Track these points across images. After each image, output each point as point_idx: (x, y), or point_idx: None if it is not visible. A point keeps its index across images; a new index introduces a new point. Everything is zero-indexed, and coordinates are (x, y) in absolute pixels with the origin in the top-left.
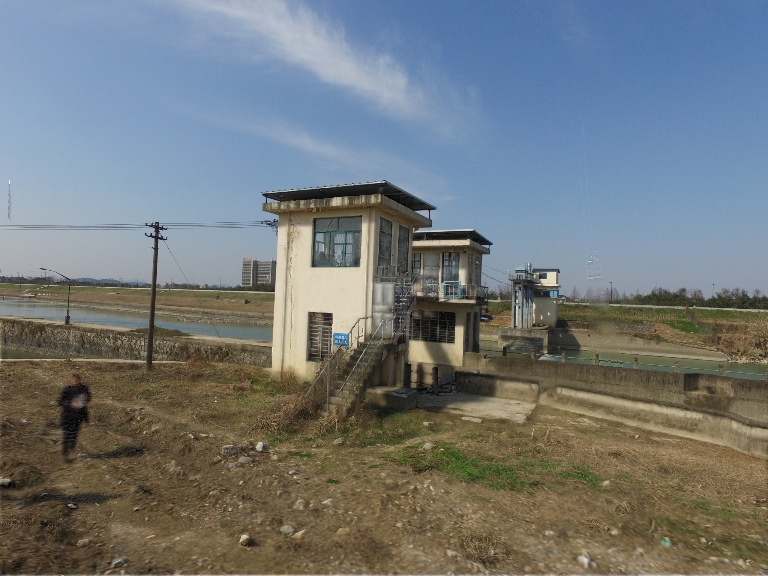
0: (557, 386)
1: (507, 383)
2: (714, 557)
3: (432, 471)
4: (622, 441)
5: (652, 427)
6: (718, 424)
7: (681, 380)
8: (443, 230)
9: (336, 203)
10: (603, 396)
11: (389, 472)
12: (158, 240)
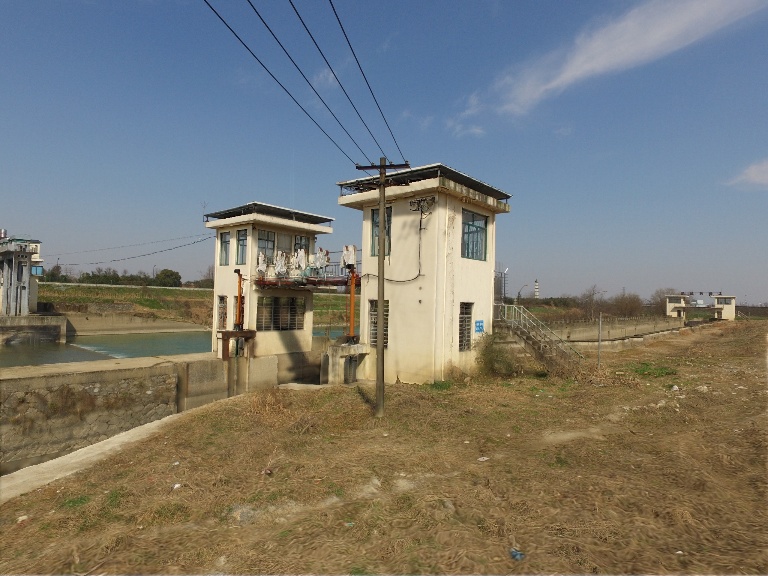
0: None
1: None
2: (704, 366)
3: None
4: None
5: None
6: None
7: None
8: None
9: None
10: None
11: None
12: None
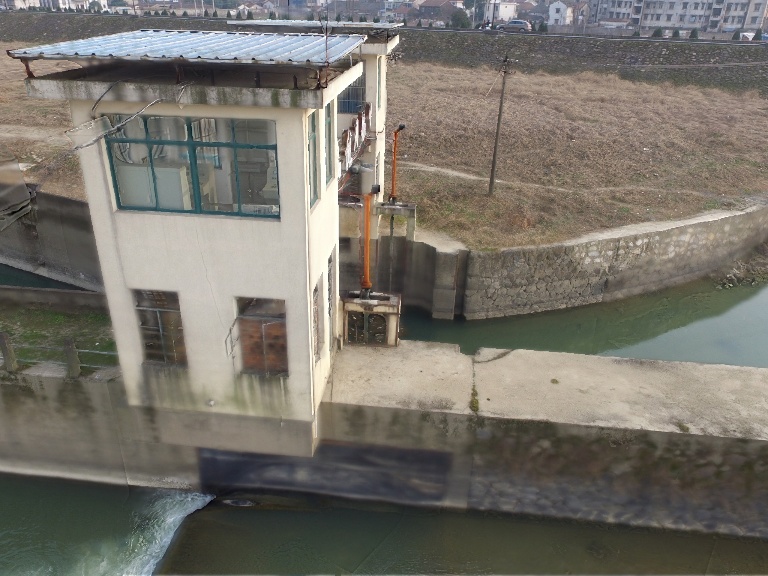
0: None
1: None
2: None
3: None
4: None
5: None
6: None
7: None
8: None
9: None
10: None
11: None
12: (504, 75)
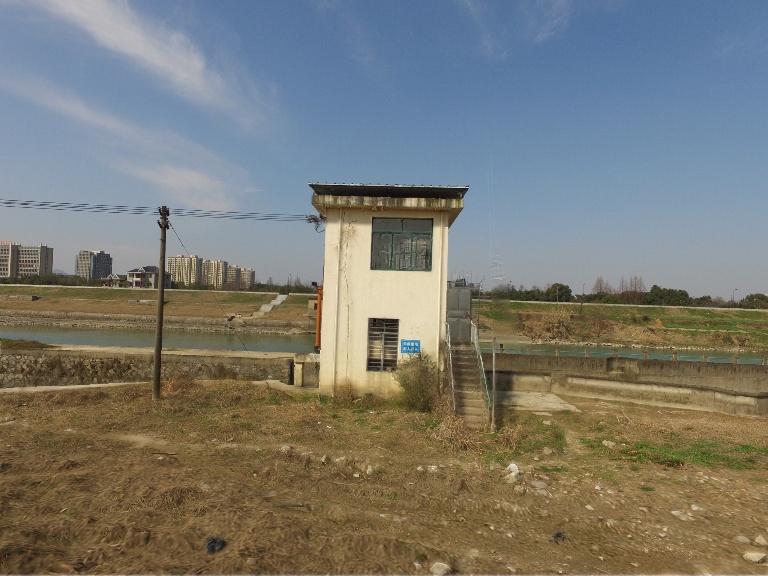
0: (568, 376)
1: (523, 377)
2: None
3: (688, 464)
4: (659, 417)
5: (655, 403)
6: (704, 396)
7: (605, 363)
8: None
9: (410, 204)
10: (611, 382)
11: (659, 471)
12: None
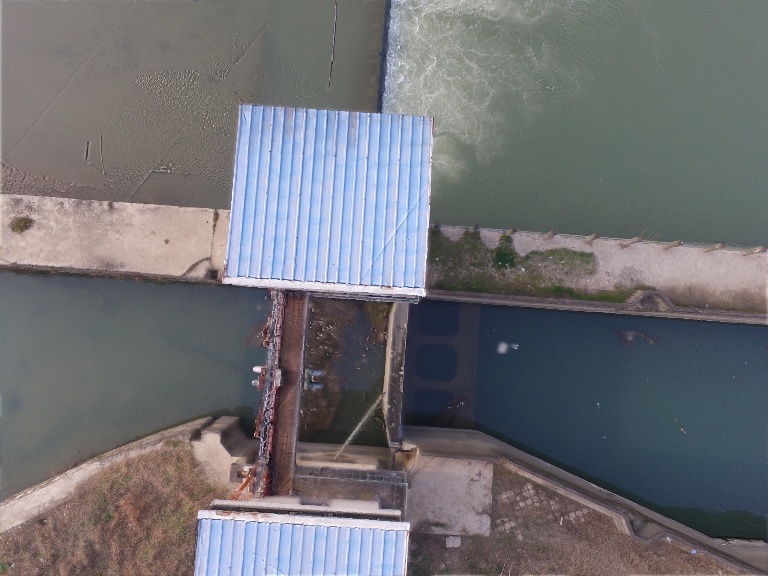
0: None
1: None
2: None
3: None
4: (551, 537)
5: (574, 495)
6: None
7: None
8: None
9: None
10: None
11: None
12: None
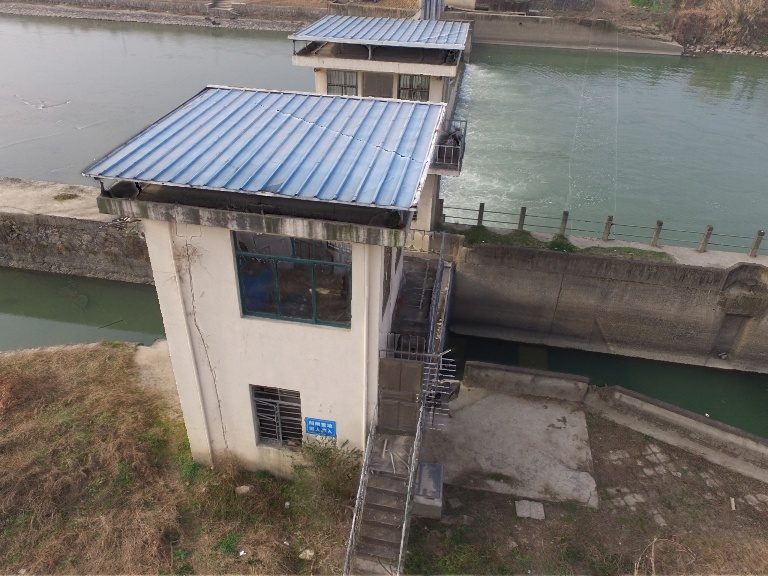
0: (616, 391)
1: (543, 380)
2: None
3: None
4: (723, 527)
5: (740, 465)
6: None
7: (723, 279)
8: (406, 43)
9: (294, 231)
10: (682, 417)
11: None
12: None
